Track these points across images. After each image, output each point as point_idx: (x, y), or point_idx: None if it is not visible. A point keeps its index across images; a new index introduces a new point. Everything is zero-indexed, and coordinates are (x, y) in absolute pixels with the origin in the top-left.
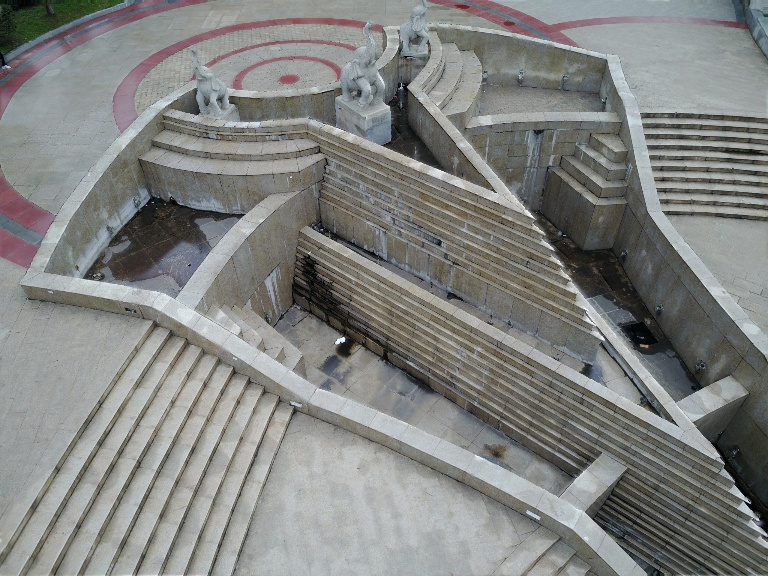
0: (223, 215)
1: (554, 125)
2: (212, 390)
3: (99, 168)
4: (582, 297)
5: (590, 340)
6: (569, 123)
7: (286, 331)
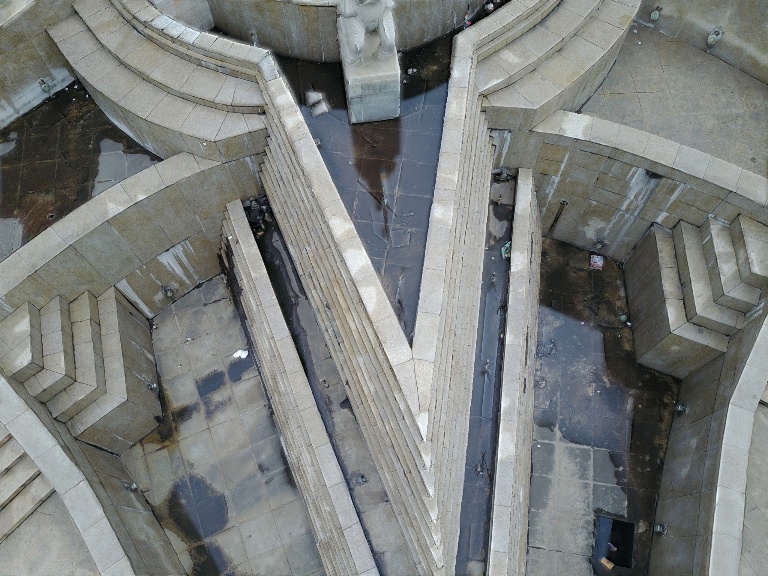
0: (137, 146)
1: (683, 177)
2: None
3: None
4: (507, 513)
5: None
6: (709, 184)
7: (193, 308)
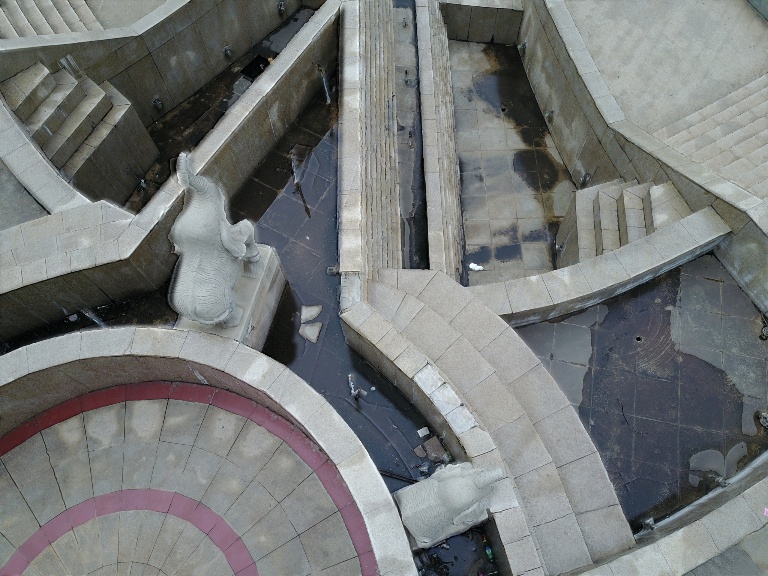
0: None
1: None
2: (709, 168)
3: (745, 513)
4: None
5: None
6: None
7: None
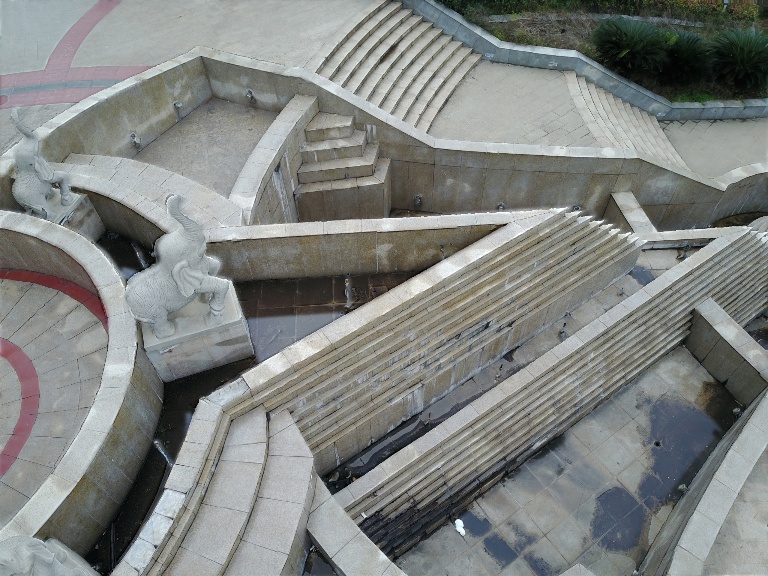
0: None
1: (282, 149)
2: None
3: None
4: None
5: (636, 252)
6: (289, 135)
7: None
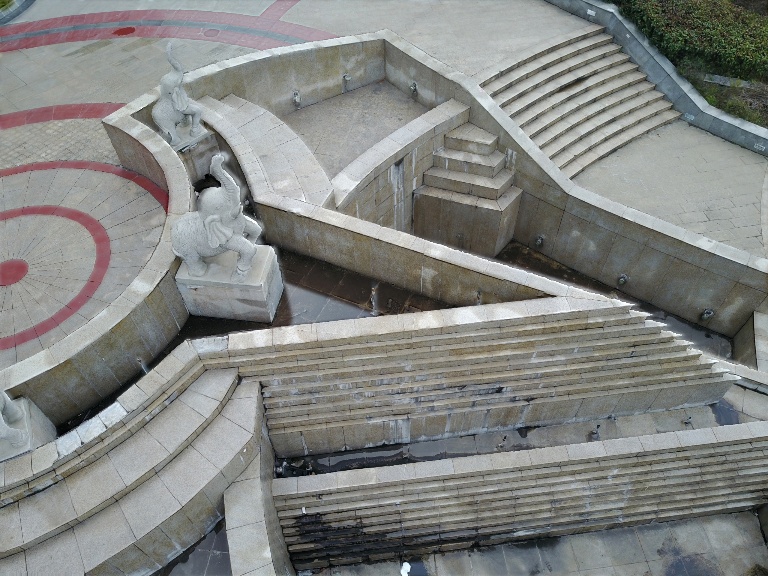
0: None
1: (411, 146)
2: None
3: None
4: None
5: (722, 385)
6: (424, 136)
7: None
